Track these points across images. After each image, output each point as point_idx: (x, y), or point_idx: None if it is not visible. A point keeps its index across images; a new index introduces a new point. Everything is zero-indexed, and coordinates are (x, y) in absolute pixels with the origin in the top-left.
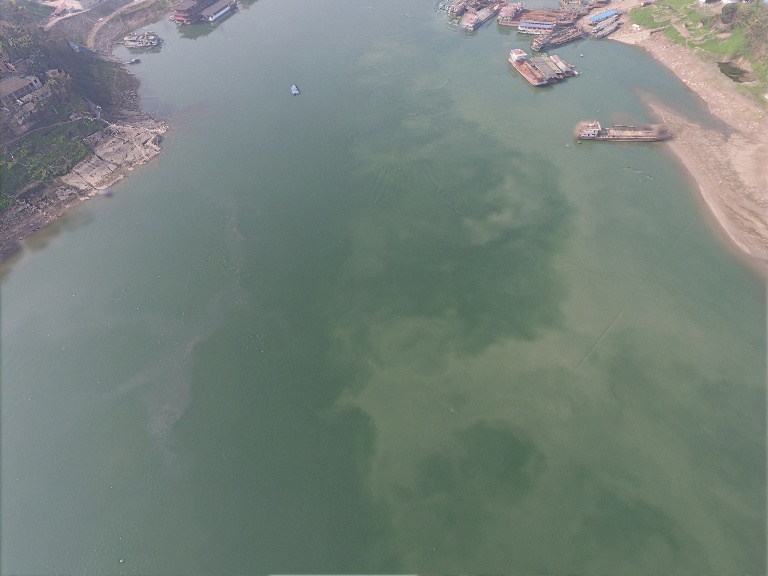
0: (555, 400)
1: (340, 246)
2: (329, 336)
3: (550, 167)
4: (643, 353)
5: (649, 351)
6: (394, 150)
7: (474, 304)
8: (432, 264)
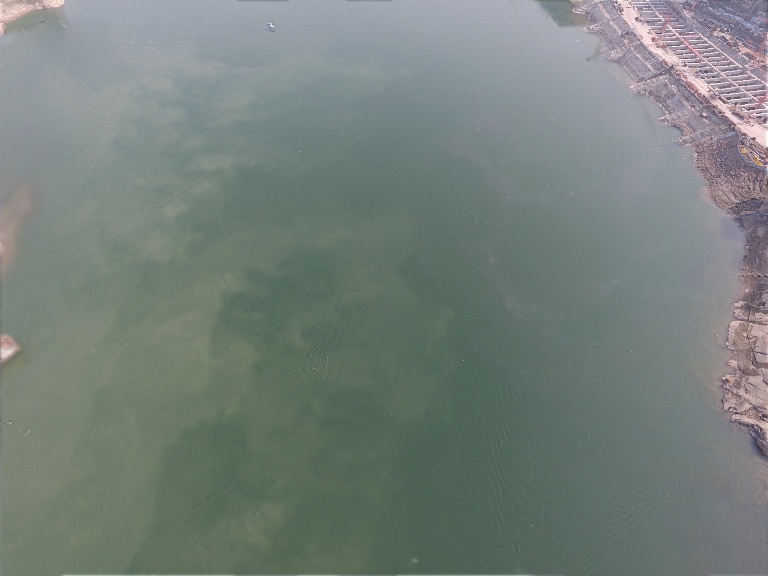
0: (236, 154)
1: (381, 244)
2: (380, 172)
3: (93, 372)
4: (161, 184)
5: (155, 186)
6: (313, 421)
7: (266, 207)
8: (293, 239)
